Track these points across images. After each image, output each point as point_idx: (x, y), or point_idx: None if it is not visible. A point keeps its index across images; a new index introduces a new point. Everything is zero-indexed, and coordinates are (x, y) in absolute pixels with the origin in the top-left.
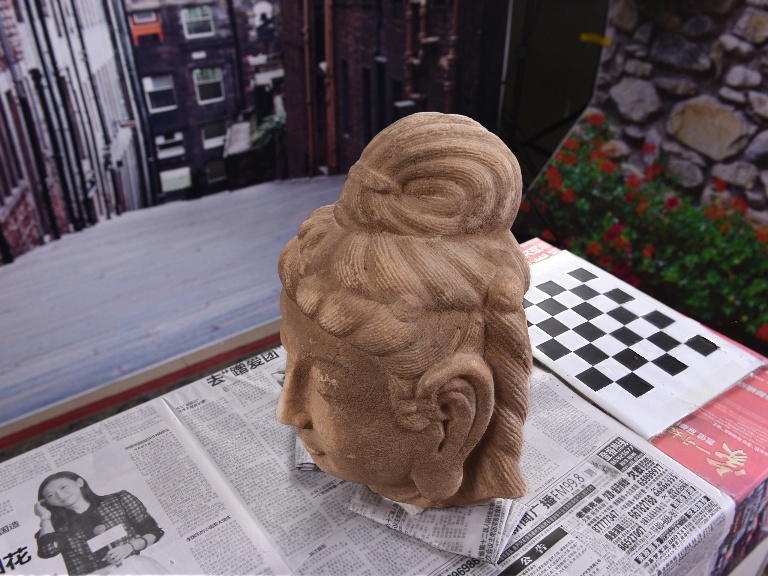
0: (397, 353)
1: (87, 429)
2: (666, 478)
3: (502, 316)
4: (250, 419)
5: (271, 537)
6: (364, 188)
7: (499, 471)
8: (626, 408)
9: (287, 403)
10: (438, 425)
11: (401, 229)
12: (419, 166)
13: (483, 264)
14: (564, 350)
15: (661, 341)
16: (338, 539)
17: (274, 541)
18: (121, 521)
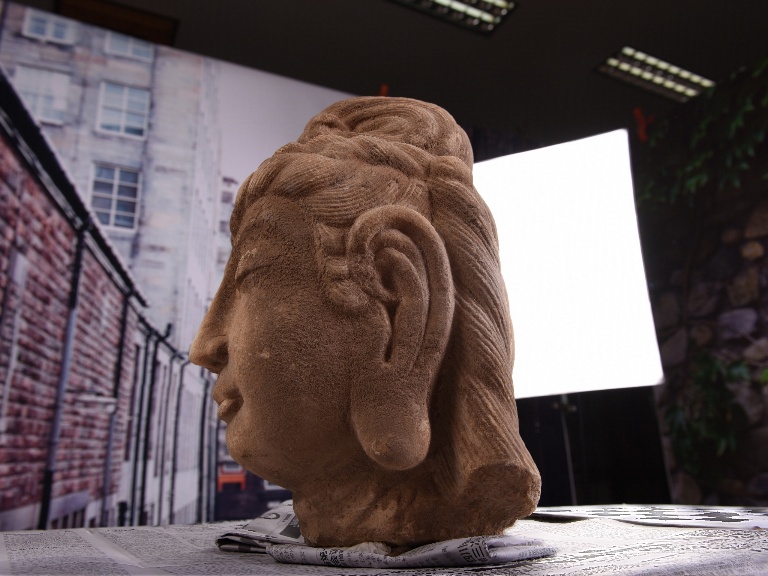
0: (323, 190)
1: None
2: None
3: (447, 181)
4: (181, 535)
5: (137, 558)
6: (314, 124)
7: (481, 414)
8: None
9: (204, 328)
10: (380, 307)
11: None
12: None
13: None
14: None
15: (757, 512)
16: None
17: None
18: None
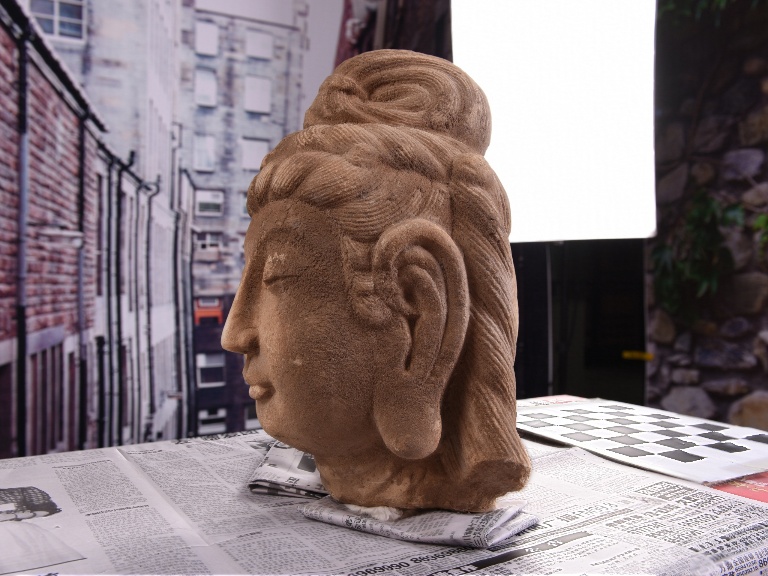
0: (349, 203)
1: (19, 458)
2: (729, 503)
3: (468, 187)
4: (208, 462)
5: (193, 523)
6: (331, 89)
7: (486, 416)
8: (671, 466)
9: (233, 318)
10: (402, 321)
11: (364, 117)
12: (384, 72)
13: (447, 143)
14: (593, 437)
15: (713, 436)
16: (280, 530)
17: (196, 525)
18: (14, 501)
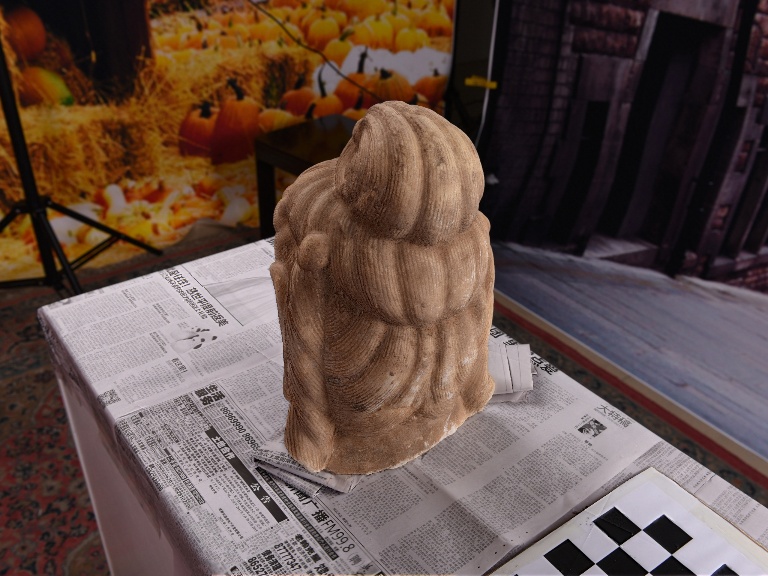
0: None
1: None
2: None
3: None
4: None
5: None
6: None
7: None
8: None
9: None
10: None
11: None
12: None
13: (319, 219)
14: (571, 572)
15: None
16: None
17: None
18: None
